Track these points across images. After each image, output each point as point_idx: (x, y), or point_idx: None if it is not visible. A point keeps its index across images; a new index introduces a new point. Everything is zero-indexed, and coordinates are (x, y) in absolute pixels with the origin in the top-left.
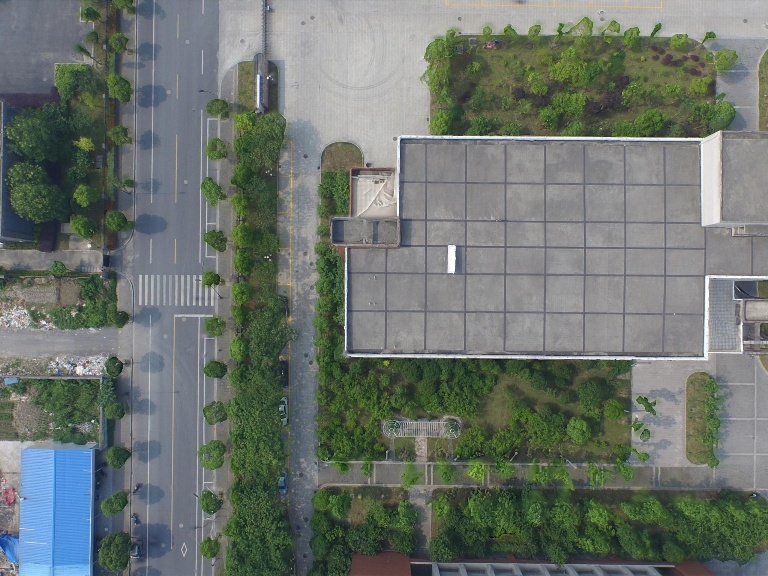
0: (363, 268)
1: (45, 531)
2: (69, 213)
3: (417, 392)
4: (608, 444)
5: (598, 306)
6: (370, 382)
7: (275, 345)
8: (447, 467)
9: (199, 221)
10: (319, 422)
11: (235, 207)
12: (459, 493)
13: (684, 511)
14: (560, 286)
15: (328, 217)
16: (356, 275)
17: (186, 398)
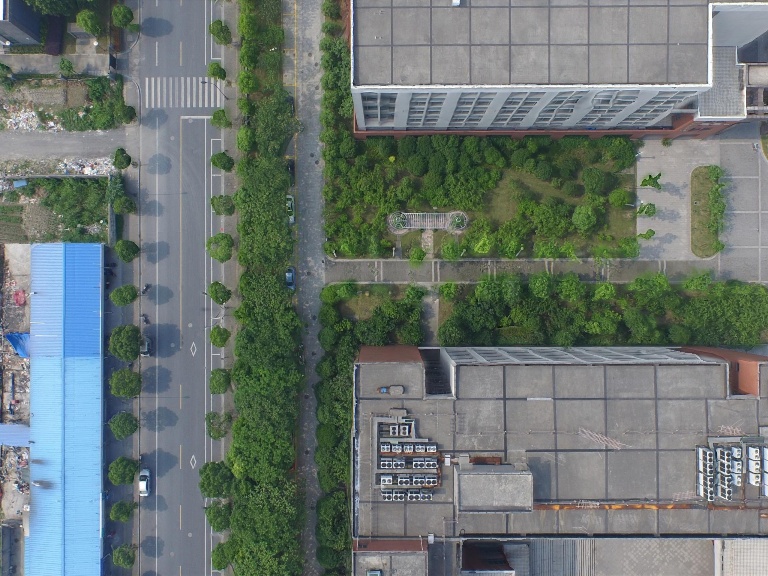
0: (369, 3)
1: (56, 324)
2: (75, 11)
3: (423, 187)
4: (613, 238)
5: (602, 37)
6: (376, 174)
7: (281, 133)
8: (453, 263)
9: (204, 24)
10: (326, 214)
11: (240, 8)
12: (466, 289)
13: (690, 287)
14: (564, 18)
15: (332, 15)
16: (362, 10)
17: (193, 199)
